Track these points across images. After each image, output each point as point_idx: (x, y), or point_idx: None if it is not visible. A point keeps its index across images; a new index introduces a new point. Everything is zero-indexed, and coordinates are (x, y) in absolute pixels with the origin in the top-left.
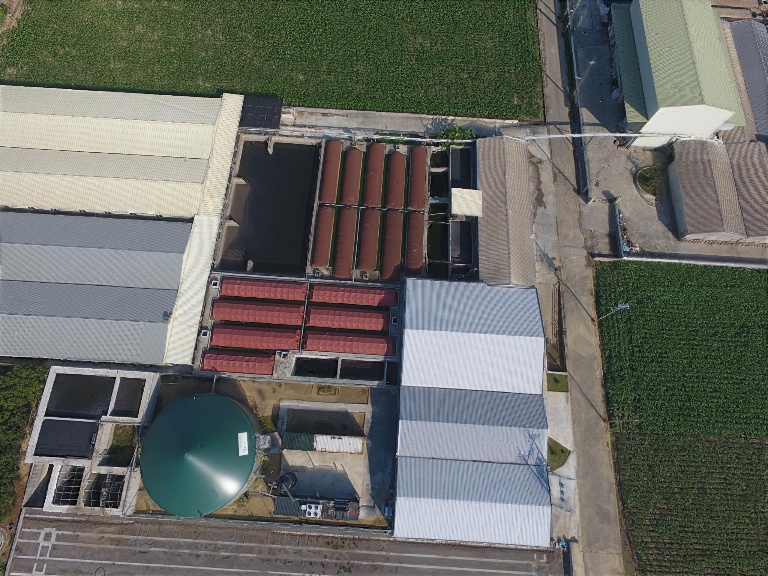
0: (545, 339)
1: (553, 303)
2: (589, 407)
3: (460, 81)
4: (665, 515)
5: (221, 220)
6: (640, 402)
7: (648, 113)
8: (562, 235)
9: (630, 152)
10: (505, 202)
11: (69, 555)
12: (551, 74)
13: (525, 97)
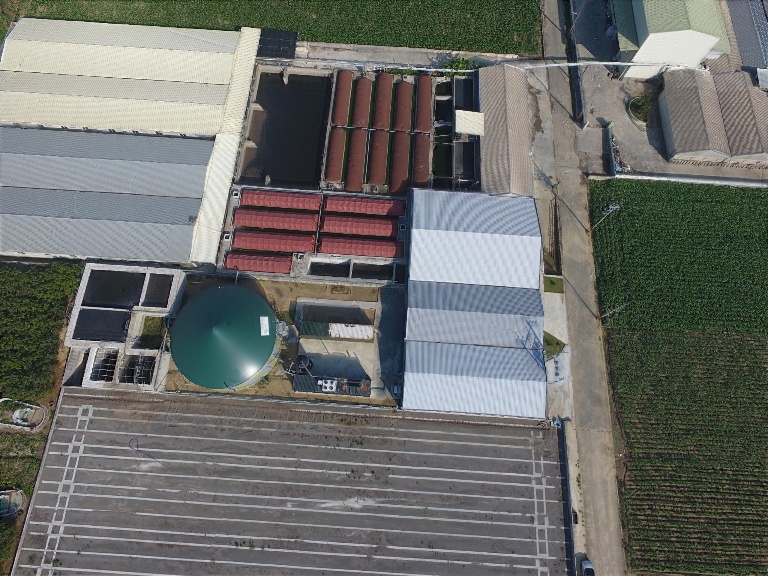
0: (542, 248)
1: (550, 217)
2: (583, 306)
3: (463, 20)
4: (652, 400)
5: (241, 140)
6: (630, 301)
7: (639, 41)
8: (559, 157)
9: (623, 84)
10: (505, 122)
11: (105, 428)
12: (549, 14)
13: (525, 35)
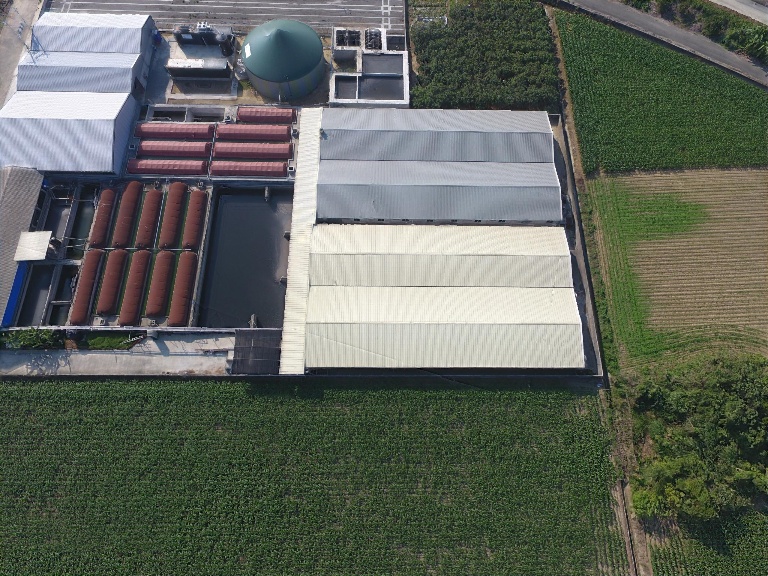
0: None
1: None
2: None
3: (4, 436)
4: None
5: None
6: None
7: None
8: None
9: None
10: None
11: (370, 19)
12: None
13: None
